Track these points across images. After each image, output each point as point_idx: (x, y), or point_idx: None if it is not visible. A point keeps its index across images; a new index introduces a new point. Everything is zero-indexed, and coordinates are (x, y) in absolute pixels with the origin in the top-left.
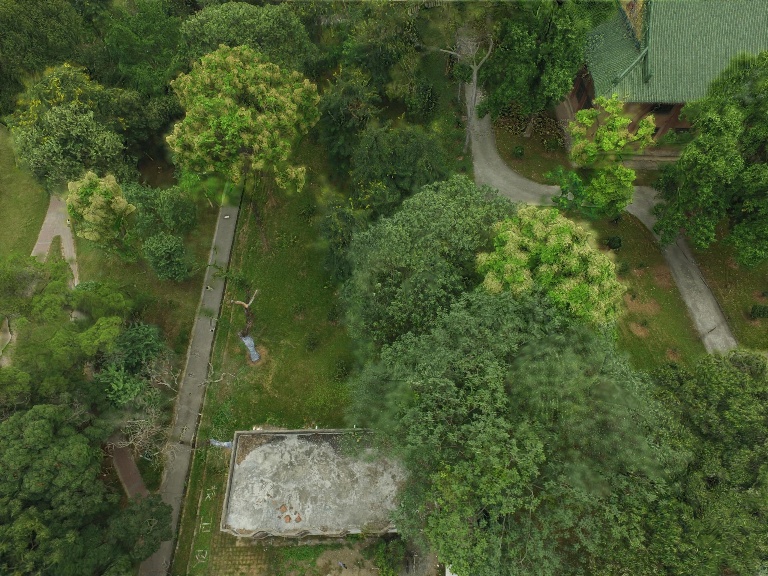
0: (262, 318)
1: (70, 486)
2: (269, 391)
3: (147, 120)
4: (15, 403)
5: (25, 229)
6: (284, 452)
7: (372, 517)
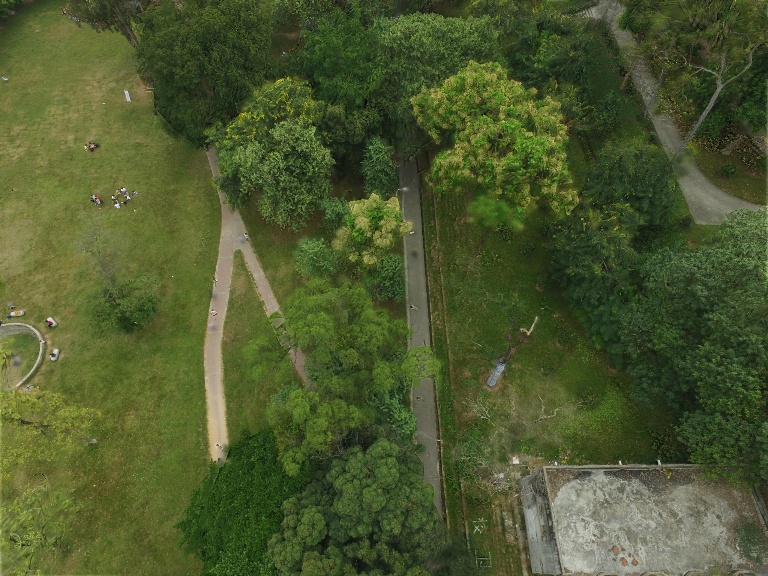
0: (486, 340)
1: (423, 528)
2: (516, 418)
3: (348, 134)
4: (345, 438)
5: (203, 243)
6: (595, 489)
7: (711, 561)
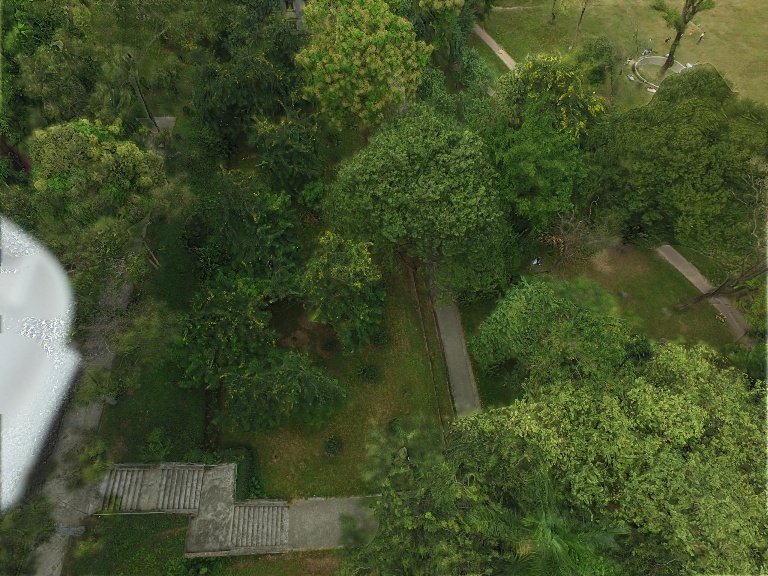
0: None
1: None
2: None
3: None
4: None
5: None
6: None
7: None
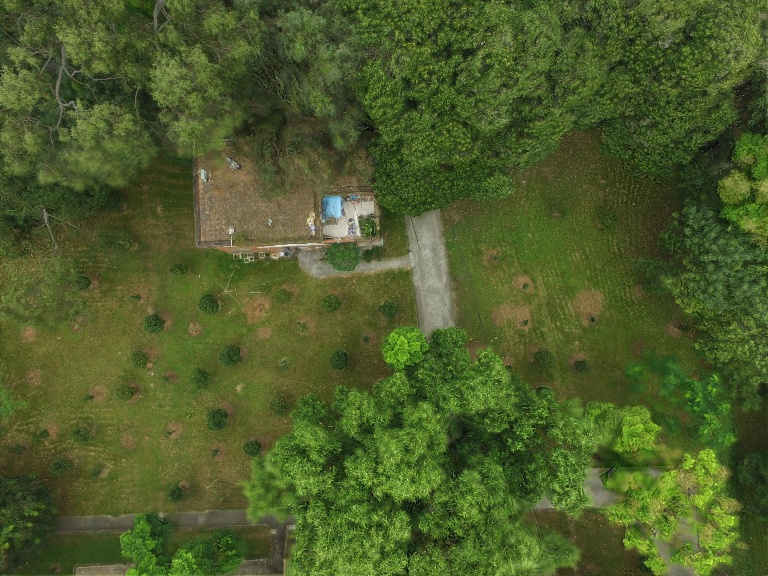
0: None
1: None
2: None
3: None
4: None
5: None
6: None
7: None
